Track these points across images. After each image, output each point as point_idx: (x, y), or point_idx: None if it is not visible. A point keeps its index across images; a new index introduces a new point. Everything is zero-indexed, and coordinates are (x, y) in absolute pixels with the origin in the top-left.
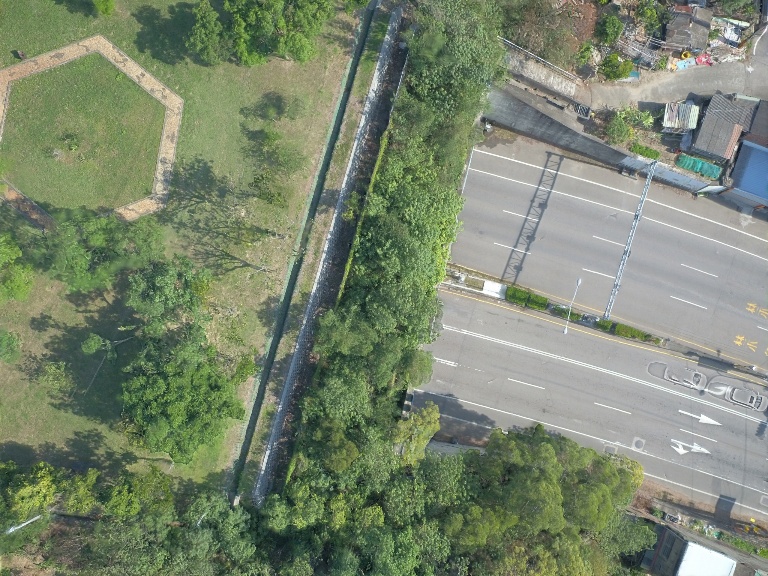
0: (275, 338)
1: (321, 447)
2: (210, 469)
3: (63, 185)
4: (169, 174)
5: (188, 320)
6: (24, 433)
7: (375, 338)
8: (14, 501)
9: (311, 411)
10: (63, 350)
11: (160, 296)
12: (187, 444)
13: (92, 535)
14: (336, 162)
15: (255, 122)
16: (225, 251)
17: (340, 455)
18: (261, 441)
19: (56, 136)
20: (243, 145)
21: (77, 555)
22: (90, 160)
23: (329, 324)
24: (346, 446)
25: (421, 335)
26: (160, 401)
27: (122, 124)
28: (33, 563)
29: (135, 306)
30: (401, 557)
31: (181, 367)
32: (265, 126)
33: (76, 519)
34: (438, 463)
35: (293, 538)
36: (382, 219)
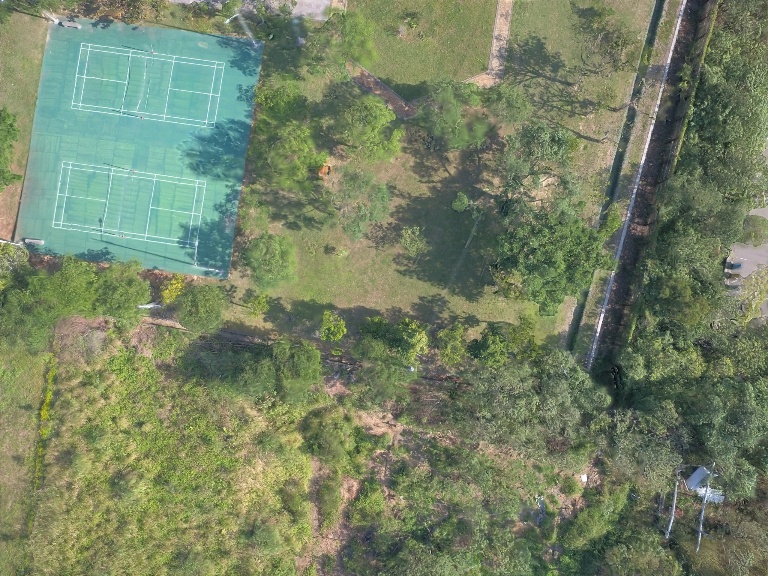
0: (603, 208)
1: (667, 304)
2: (548, 331)
3: (405, 62)
4: (504, 50)
5: (526, 189)
6: (372, 298)
7: (720, 199)
8: (408, 344)
9: (653, 272)
10: (407, 219)
11: (538, 152)
12: (560, 294)
13: (443, 392)
14: (661, 38)
15: (585, 0)
16: (560, 123)
17: (694, 308)
18: (595, 305)
19: (397, 15)
20: (574, 22)
21: (433, 410)
22: (429, 38)
23: (678, 185)
24: (698, 300)
25: (754, 200)
26: (542, 250)
27: (459, 3)
28: (381, 421)
29: (508, 164)
30: (763, 401)
31: (560, 219)
32: (594, 4)
33: (423, 379)
34: (764, 325)
35: (623, 399)
36: (722, 87)
